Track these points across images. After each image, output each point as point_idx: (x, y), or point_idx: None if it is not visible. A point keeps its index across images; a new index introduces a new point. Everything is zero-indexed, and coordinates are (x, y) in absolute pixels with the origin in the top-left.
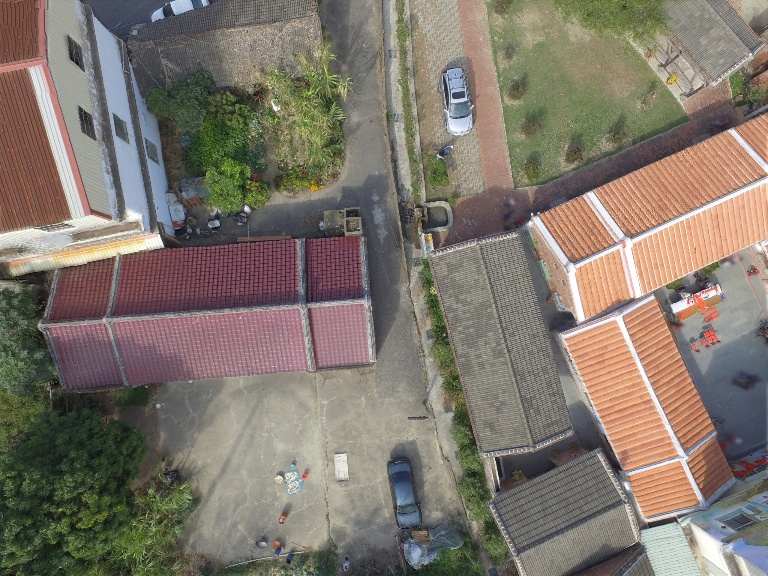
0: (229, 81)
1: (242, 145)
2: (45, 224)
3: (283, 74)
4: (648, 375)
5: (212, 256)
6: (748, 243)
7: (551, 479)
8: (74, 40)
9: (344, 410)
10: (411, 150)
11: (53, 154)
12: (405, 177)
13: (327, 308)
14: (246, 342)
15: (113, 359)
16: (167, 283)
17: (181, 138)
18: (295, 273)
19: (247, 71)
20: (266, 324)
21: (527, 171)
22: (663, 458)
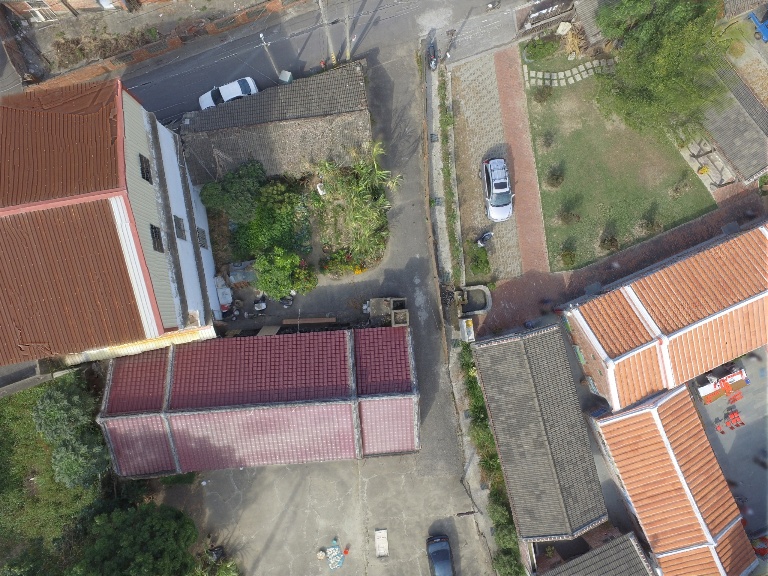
0: (278, 170)
1: (288, 229)
2: (120, 344)
3: (332, 165)
4: (680, 464)
5: (264, 346)
6: None
7: (586, 562)
8: (144, 156)
9: (384, 487)
10: (451, 234)
11: (131, 279)
12: (445, 260)
13: (376, 401)
14: (297, 433)
15: (167, 447)
16: (221, 375)
17: (228, 221)
18: (345, 366)
19: (296, 161)
20: (318, 416)
21: (564, 259)
22: (692, 543)
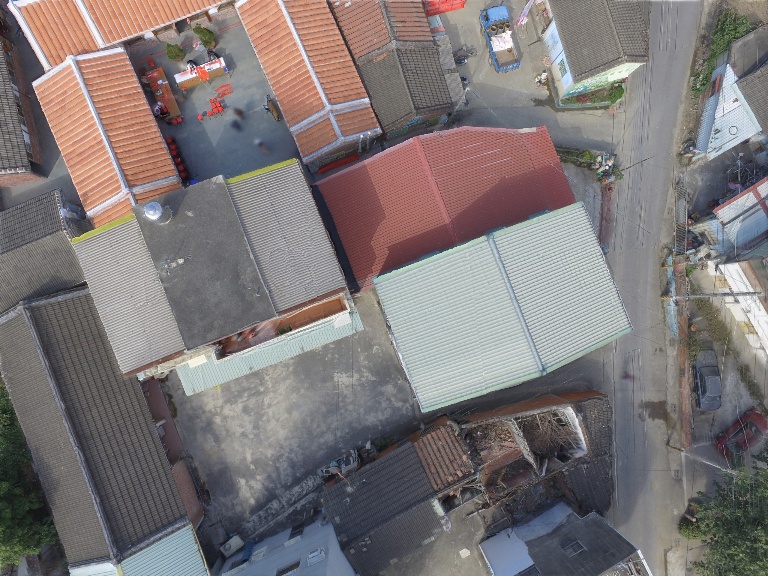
0: None
1: None
2: None
3: None
4: (102, 117)
5: None
6: (213, 1)
7: (6, 215)
8: None
9: None
10: None
11: None
12: None
13: None
14: None
15: None
16: None
17: None
18: None
19: None
20: None
21: None
22: (113, 195)
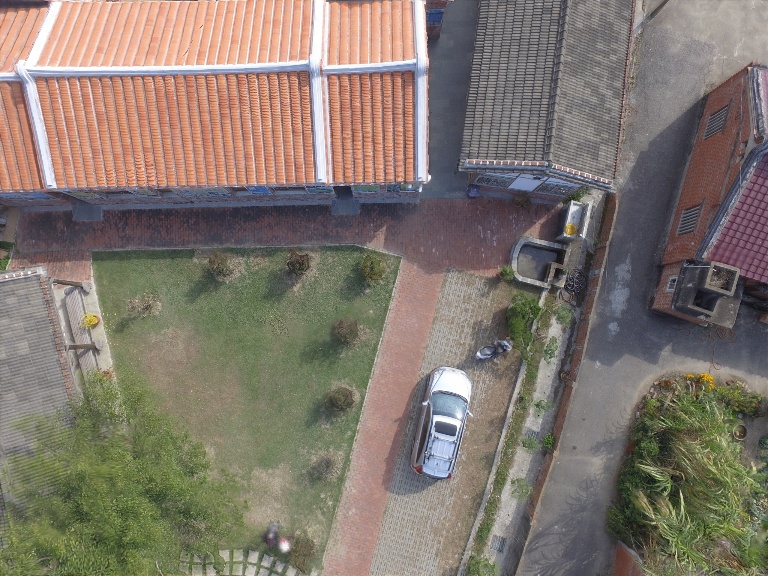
0: None
1: None
2: None
3: None
4: None
5: None
6: (115, 6)
7: None
8: None
9: (767, 51)
10: (531, 379)
11: None
12: None
13: None
14: None
15: None
16: None
17: None
18: None
19: None
20: None
21: None
22: None
